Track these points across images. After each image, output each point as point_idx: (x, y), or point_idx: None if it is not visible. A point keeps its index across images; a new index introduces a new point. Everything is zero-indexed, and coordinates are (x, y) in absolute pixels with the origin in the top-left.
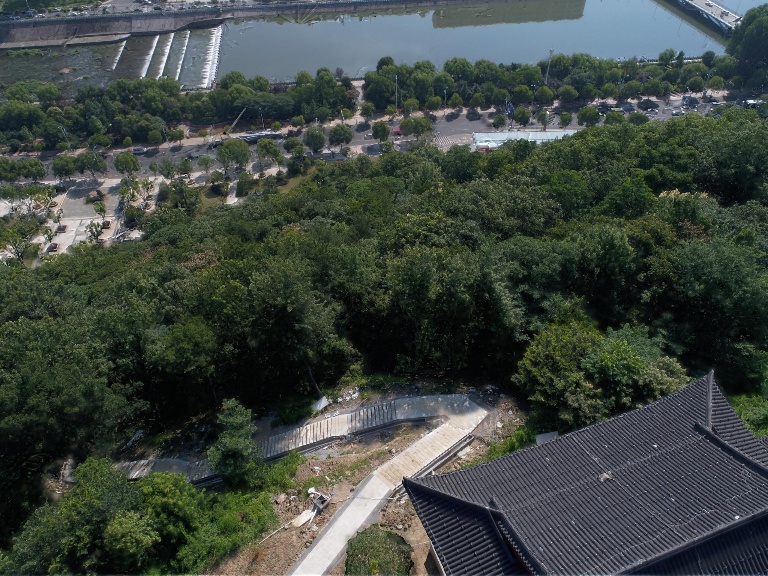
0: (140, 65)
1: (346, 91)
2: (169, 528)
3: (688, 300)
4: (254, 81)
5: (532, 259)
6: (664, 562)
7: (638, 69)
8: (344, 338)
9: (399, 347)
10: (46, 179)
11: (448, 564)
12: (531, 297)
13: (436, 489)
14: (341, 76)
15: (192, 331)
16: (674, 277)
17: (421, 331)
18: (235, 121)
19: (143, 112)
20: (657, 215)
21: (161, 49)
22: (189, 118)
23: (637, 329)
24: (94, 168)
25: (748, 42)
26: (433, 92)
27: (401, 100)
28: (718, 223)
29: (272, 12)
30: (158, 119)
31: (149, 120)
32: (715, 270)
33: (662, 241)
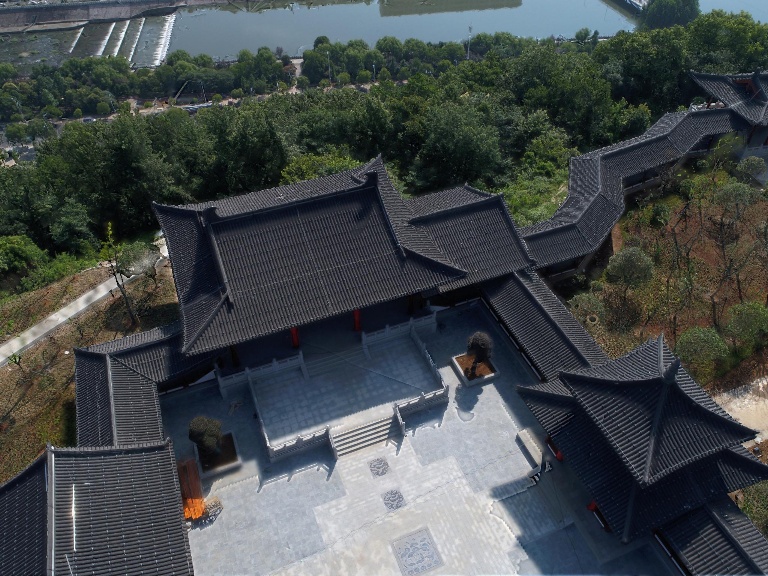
0: (96, 49)
1: (283, 67)
2: (15, 263)
3: (437, 154)
4: (198, 58)
5: (315, 120)
6: (276, 214)
7: (556, 47)
8: (180, 185)
9: (224, 193)
10: (0, 146)
11: (169, 242)
12: (314, 148)
13: (170, 206)
14: (281, 54)
15: (51, 161)
16: (422, 134)
17: (229, 170)
18: (178, 93)
19: (93, 87)
20: (431, 100)
21: (116, 34)
22: (137, 93)
23: (385, 165)
24: (45, 135)
25: (651, 20)
26: (363, 67)
27: (334, 74)
28: (474, 105)
29: (223, 0)
30: (107, 93)
31: (98, 93)
32: (442, 123)
33: (418, 111)
